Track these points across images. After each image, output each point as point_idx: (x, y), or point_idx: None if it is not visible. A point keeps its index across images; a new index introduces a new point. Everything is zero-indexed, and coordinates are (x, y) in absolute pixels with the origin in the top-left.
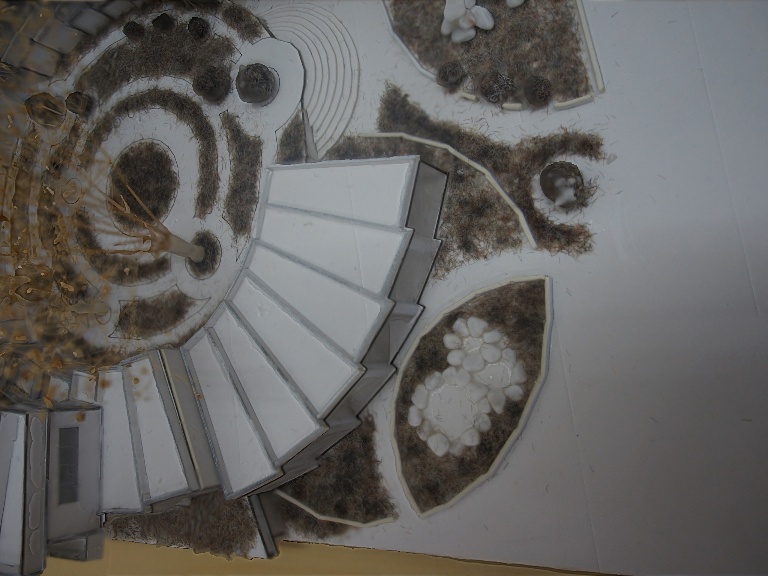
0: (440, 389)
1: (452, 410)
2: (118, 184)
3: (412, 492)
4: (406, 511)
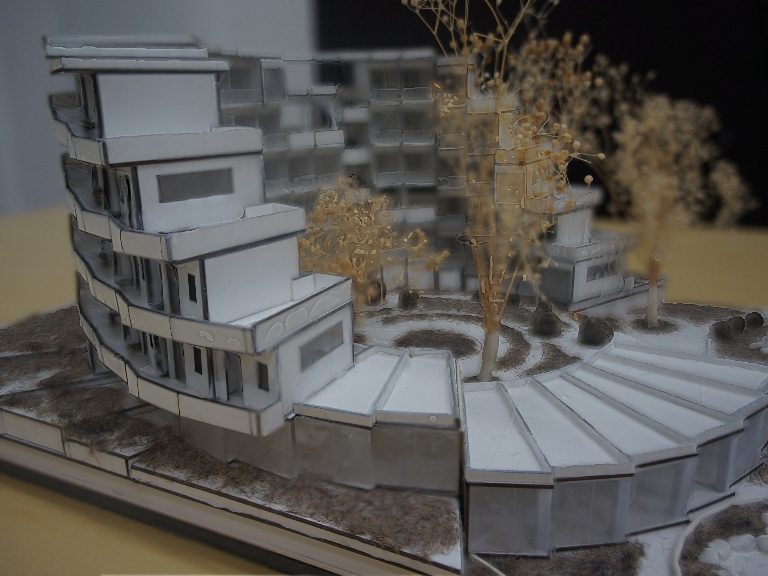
0: (747, 554)
1: (764, 573)
2: (413, 336)
3: None
4: None
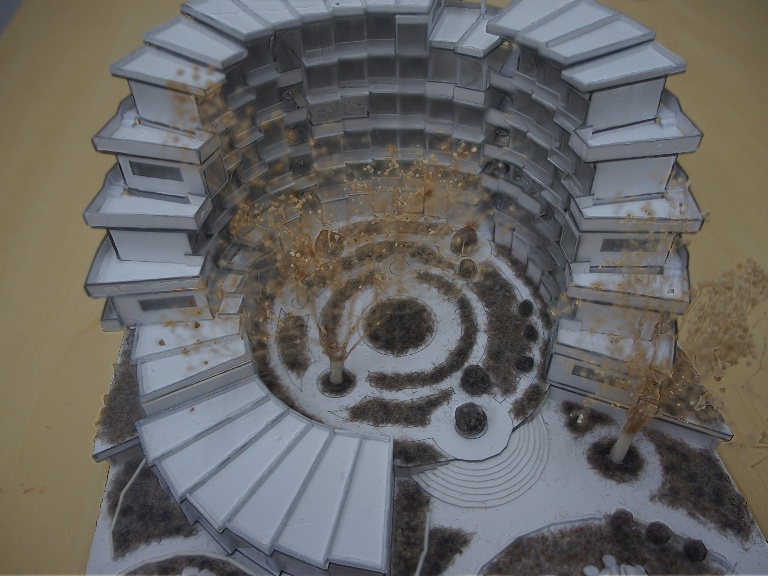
0: None
1: None
2: (402, 305)
3: (131, 573)
4: (118, 568)
